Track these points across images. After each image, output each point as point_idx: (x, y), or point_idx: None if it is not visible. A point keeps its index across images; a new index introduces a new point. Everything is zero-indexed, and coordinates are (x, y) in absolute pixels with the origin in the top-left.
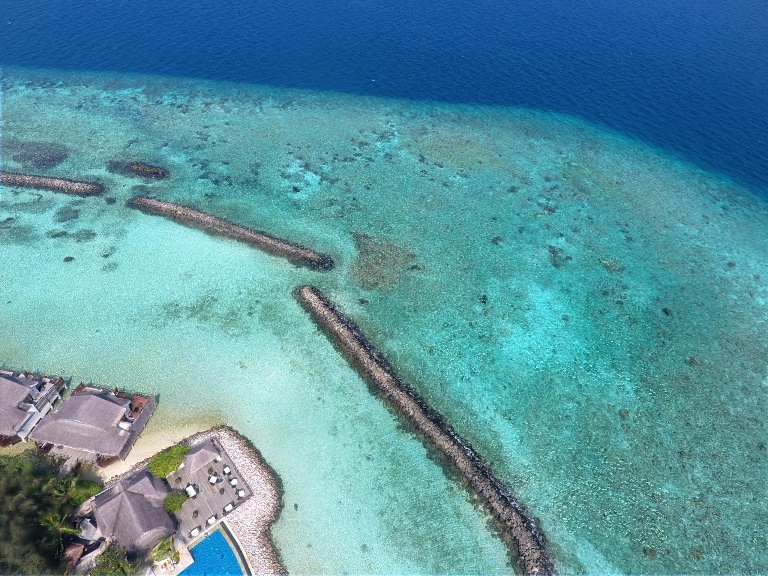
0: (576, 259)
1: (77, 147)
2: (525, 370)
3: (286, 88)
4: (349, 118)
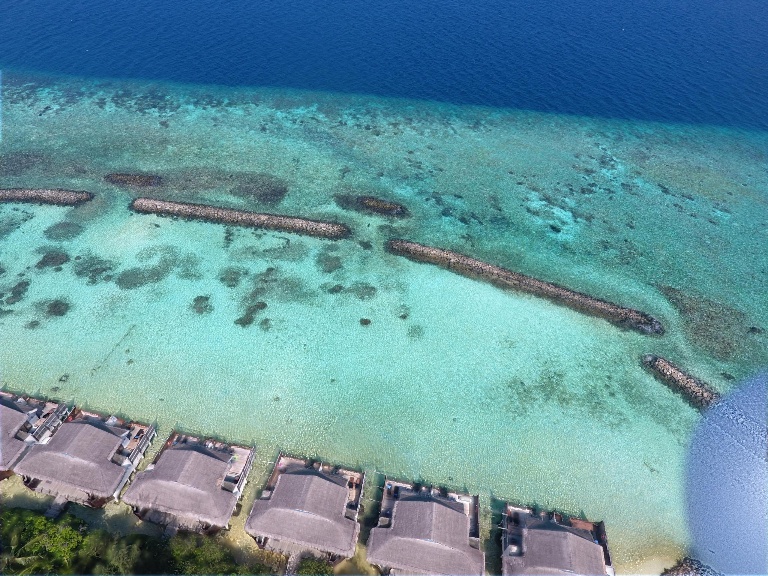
0: None
1: (290, 178)
2: None
3: (464, 105)
4: (553, 140)
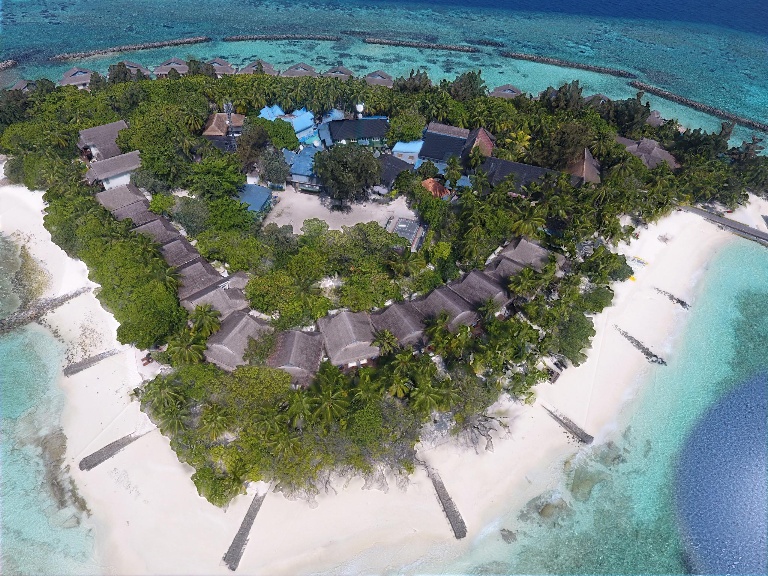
0: (761, 77)
1: (437, 34)
2: (762, 107)
3: (519, 10)
4: (576, 24)
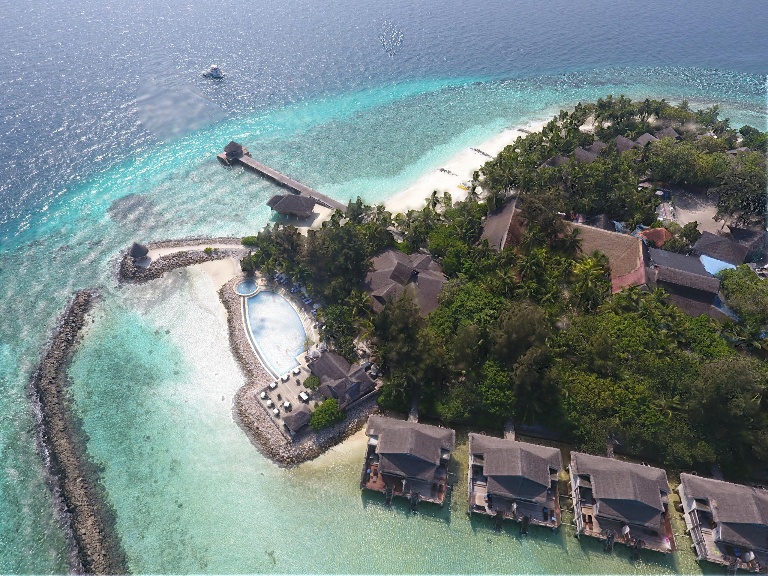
0: None
1: None
2: None
3: None
4: None
